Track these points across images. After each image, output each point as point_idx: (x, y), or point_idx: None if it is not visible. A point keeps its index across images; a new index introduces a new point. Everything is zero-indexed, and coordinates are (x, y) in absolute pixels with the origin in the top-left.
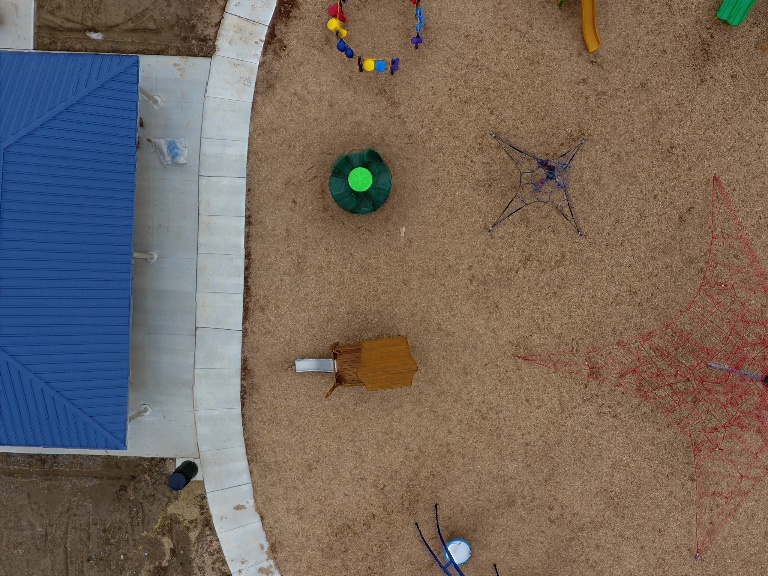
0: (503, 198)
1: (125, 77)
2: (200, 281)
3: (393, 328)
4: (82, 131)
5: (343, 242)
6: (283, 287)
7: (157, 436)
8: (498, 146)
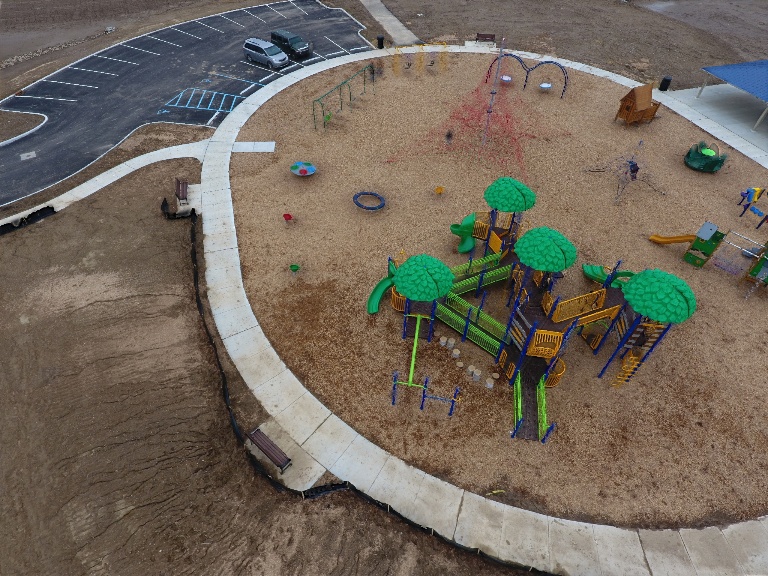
0: None
1: None
2: None
3: None
4: None
5: None
6: None
7: (684, 94)
8: None
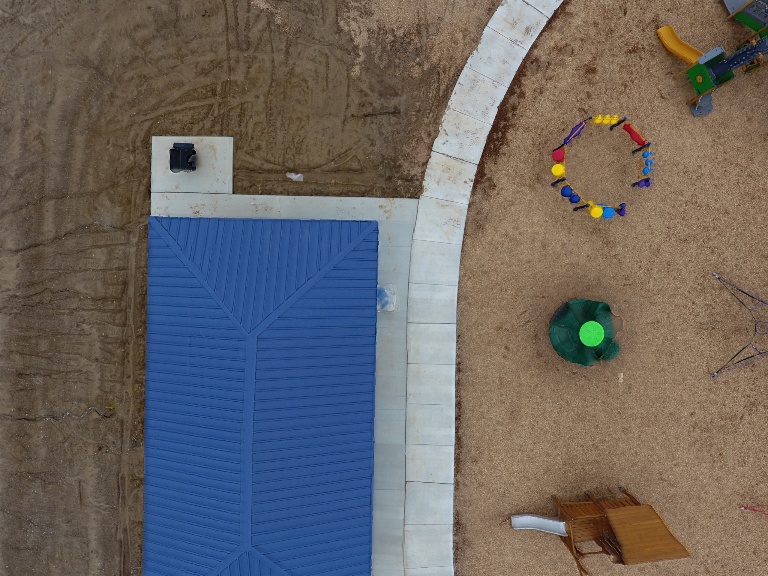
0: (727, 341)
1: (366, 245)
2: (409, 433)
3: (612, 479)
4: (328, 308)
5: (558, 389)
6: (496, 437)
7: None
8: (721, 287)
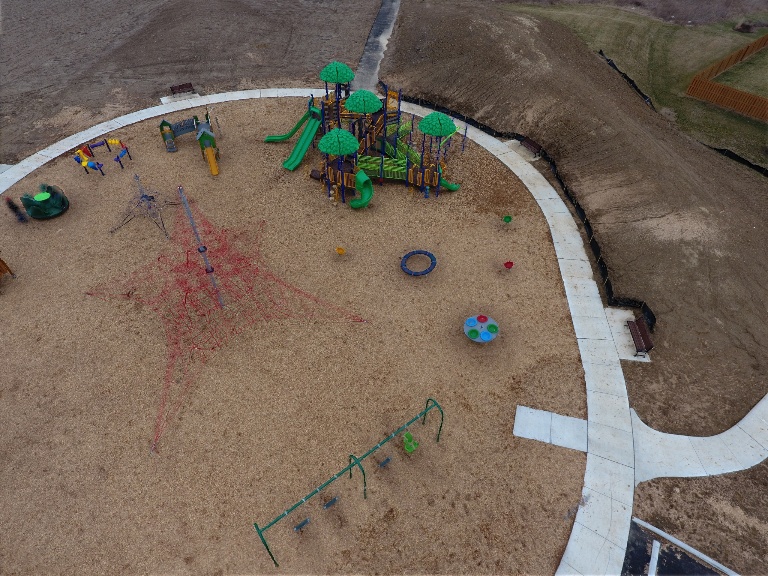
0: None
1: None
2: None
3: (14, 272)
4: None
5: (19, 232)
6: None
7: None
8: None
